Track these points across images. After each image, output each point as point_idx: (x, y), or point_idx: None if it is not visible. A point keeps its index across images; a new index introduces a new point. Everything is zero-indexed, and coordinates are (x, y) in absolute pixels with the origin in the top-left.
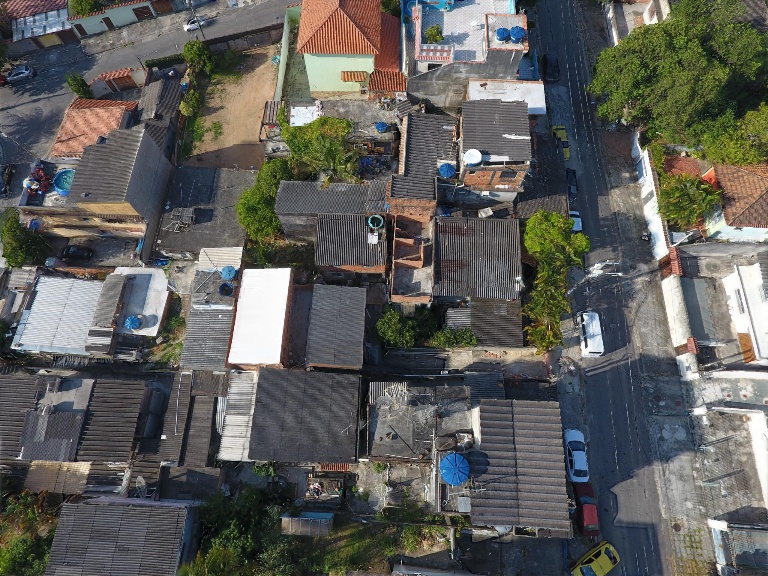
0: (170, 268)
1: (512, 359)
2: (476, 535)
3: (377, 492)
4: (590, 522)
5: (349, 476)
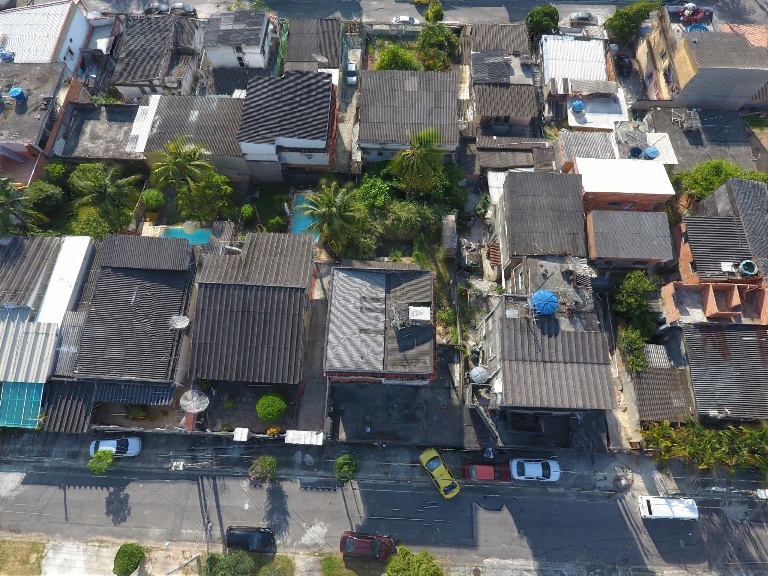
0: (636, 121)
1: (619, 417)
2: (454, 367)
3: (481, 284)
4: (479, 471)
5: (480, 274)
